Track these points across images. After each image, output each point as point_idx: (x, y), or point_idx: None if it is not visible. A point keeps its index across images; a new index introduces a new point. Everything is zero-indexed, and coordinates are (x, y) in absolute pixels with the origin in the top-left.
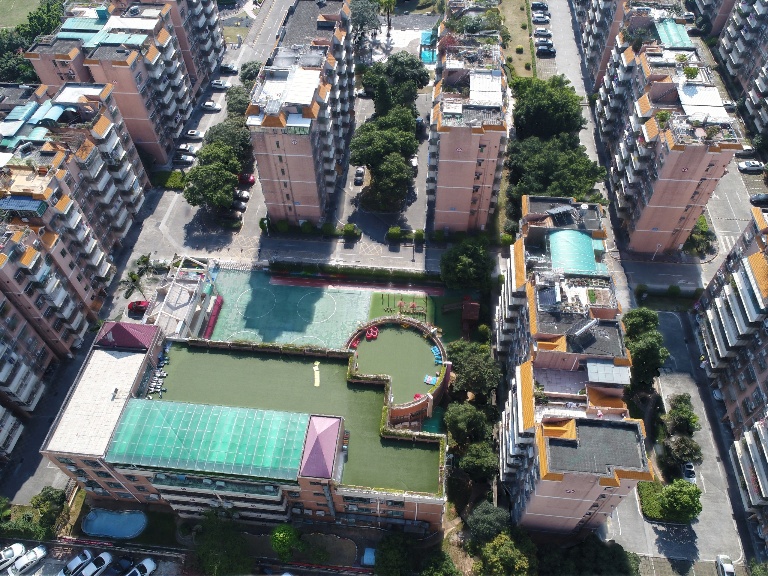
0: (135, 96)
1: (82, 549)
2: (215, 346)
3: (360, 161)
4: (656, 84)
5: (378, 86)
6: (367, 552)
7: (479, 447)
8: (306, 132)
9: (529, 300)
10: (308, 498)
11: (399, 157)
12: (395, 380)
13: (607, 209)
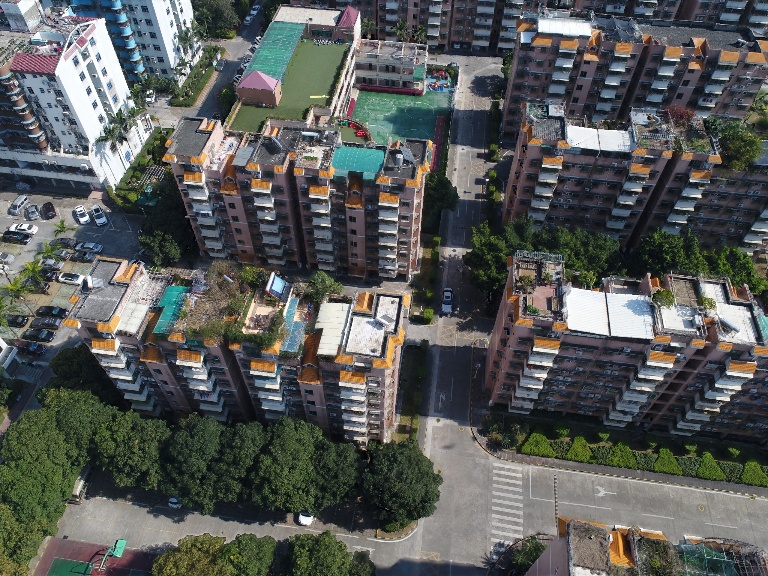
0: None
1: None
2: None
3: None
4: None
5: None
6: None
7: None
8: None
9: None
10: None
11: None
12: None
13: None
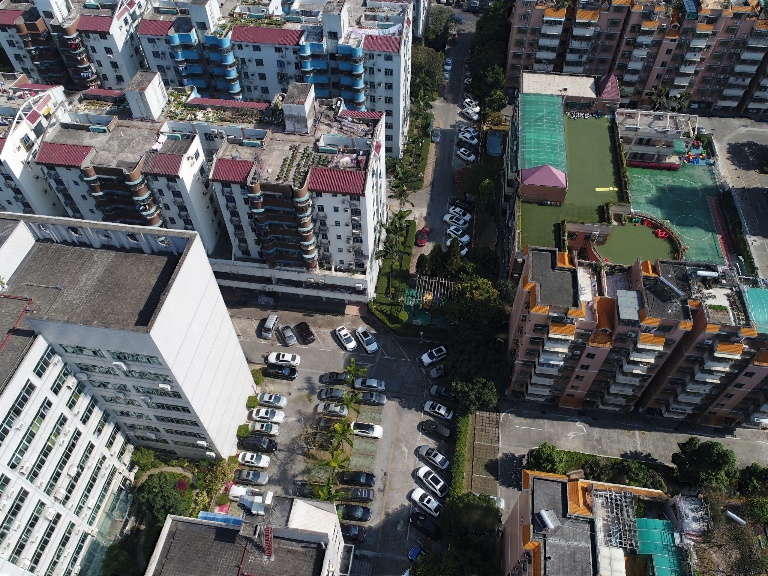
0: None
1: None
2: None
3: None
4: None
5: None
6: None
7: None
8: None
9: None
10: None
11: None
12: (618, 248)
13: None
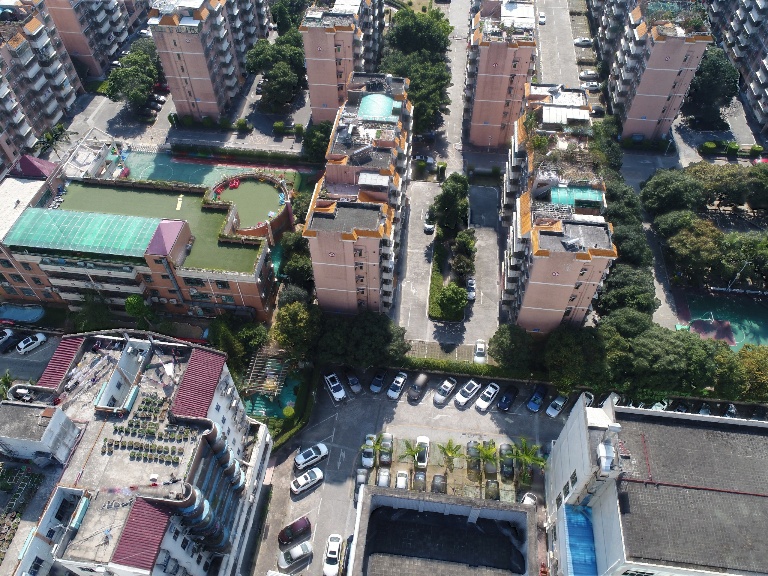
0: (69, 11)
1: None
2: (104, 183)
3: (254, 68)
4: (486, 2)
5: (278, 12)
6: (207, 330)
7: (297, 255)
8: (196, 31)
9: (331, 136)
10: (160, 283)
11: (285, 65)
12: (245, 214)
13: (462, 115)
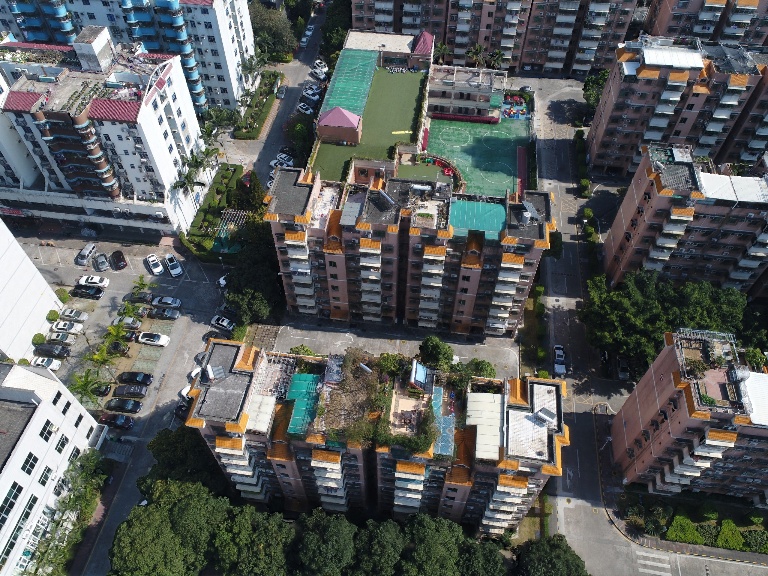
0: (669, 13)
1: (322, 90)
2: None
3: None
4: None
5: None
6: None
7: None
8: None
9: None
10: None
11: None
12: None
13: None
